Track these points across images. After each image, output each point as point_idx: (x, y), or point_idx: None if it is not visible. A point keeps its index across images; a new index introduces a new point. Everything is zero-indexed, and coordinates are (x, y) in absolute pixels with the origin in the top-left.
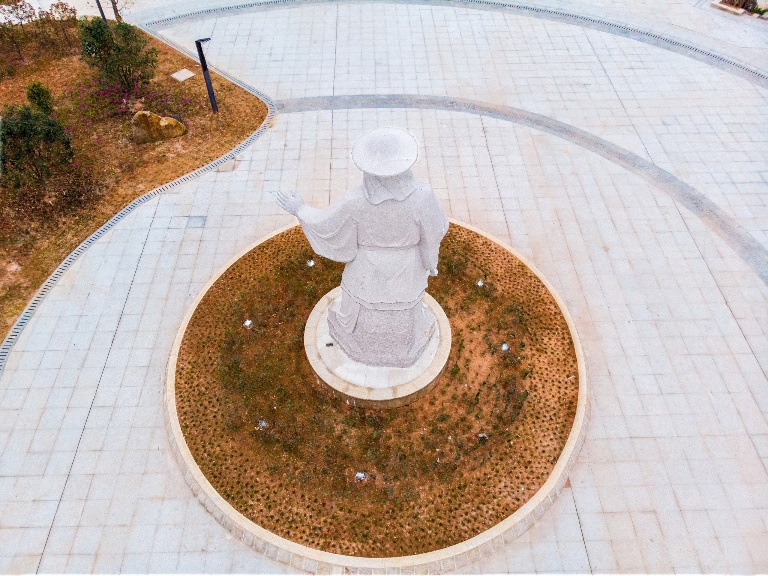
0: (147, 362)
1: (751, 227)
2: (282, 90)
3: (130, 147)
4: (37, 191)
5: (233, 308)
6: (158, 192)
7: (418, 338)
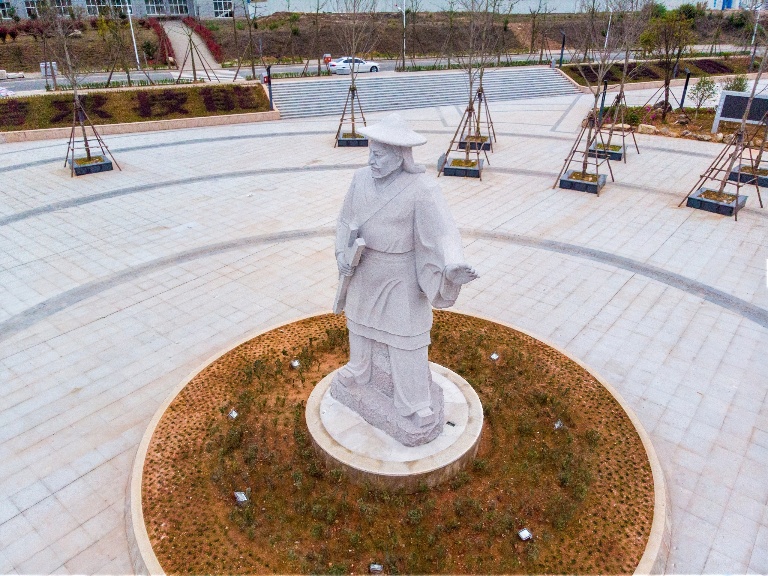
0: None
1: None
2: None
3: None
4: None
5: None
6: None
7: None
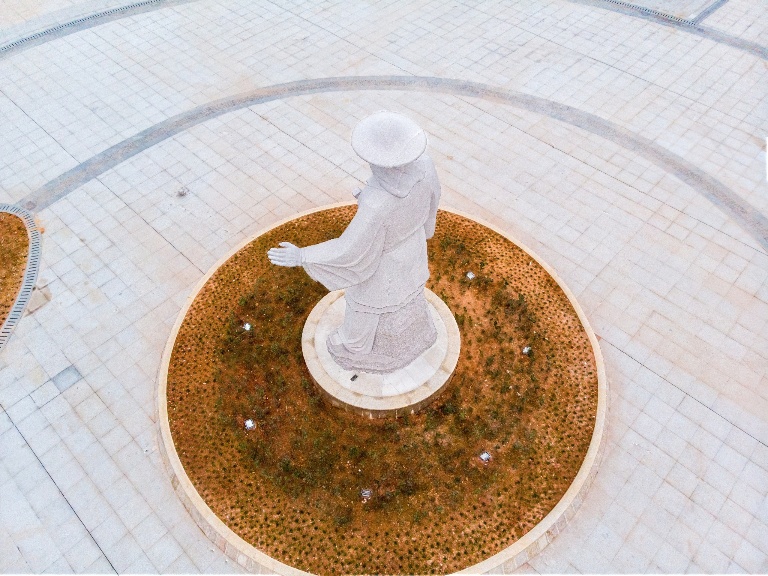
0: (178, 550)
1: (516, 87)
2: (12, 189)
3: None
4: None
5: None
6: None
7: None
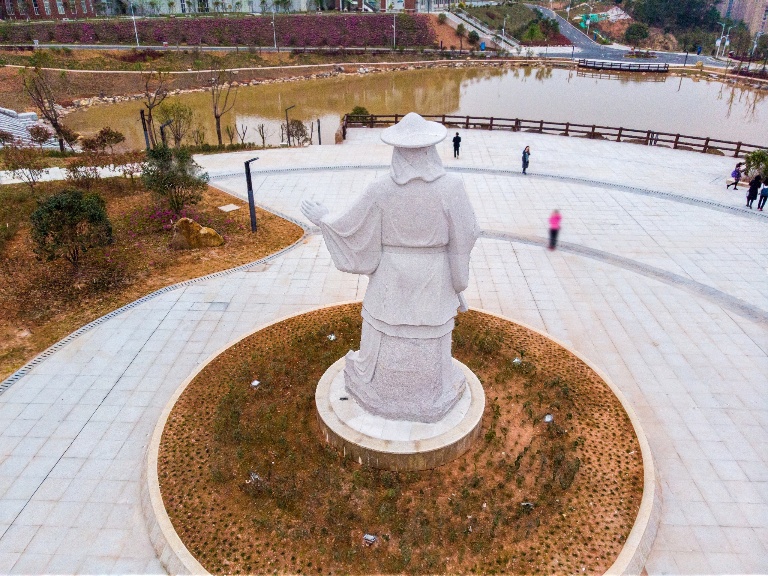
0: (137, 419)
1: None
2: None
3: (168, 252)
4: (69, 279)
5: (242, 367)
6: (186, 284)
7: (446, 390)
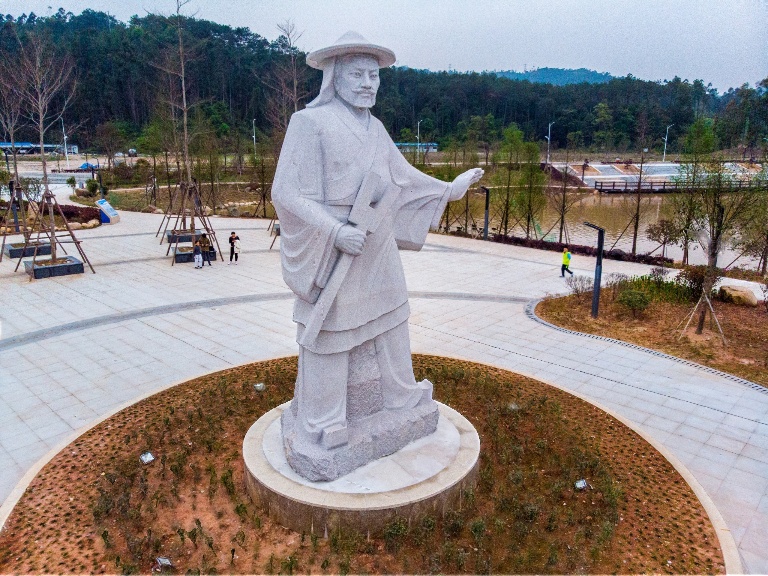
0: None
1: None
2: None
3: None
4: None
5: None
6: None
7: None
